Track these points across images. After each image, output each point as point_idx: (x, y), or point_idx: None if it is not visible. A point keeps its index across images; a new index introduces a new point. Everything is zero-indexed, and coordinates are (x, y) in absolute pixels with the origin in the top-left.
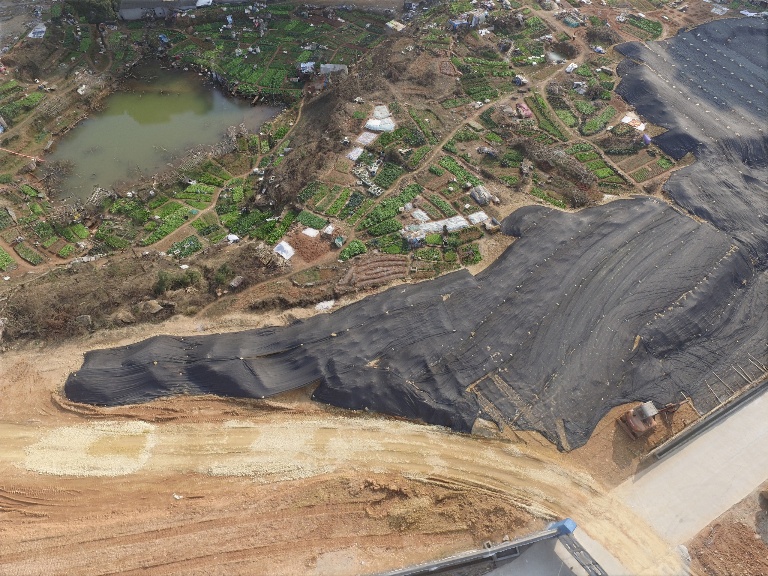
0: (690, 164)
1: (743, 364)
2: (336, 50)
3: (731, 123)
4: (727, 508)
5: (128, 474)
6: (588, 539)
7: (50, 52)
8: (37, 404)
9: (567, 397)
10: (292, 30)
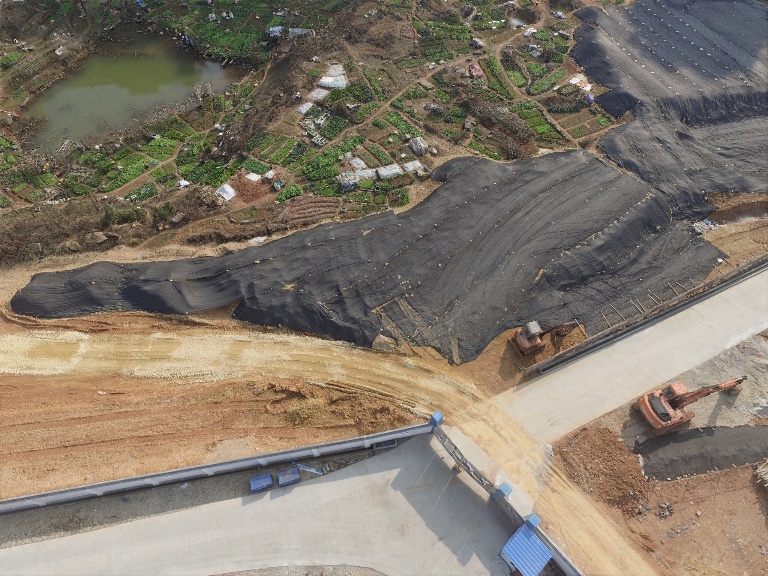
0: (628, 122)
1: (641, 298)
2: (307, 16)
3: (673, 83)
4: (597, 416)
5: (60, 374)
6: (462, 436)
7: (30, 14)
8: None
9: (465, 320)
10: None
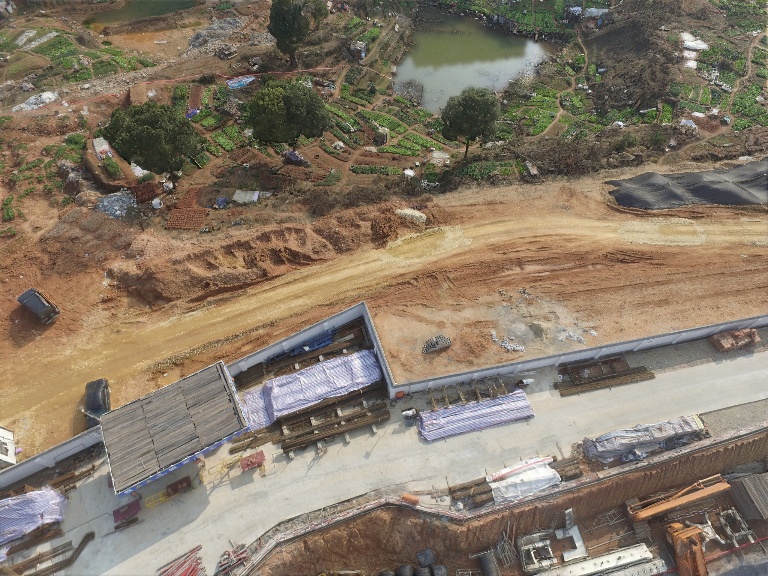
0: None
1: None
2: None
3: None
4: None
5: (700, 244)
6: None
7: None
8: (600, 209)
9: None
10: None
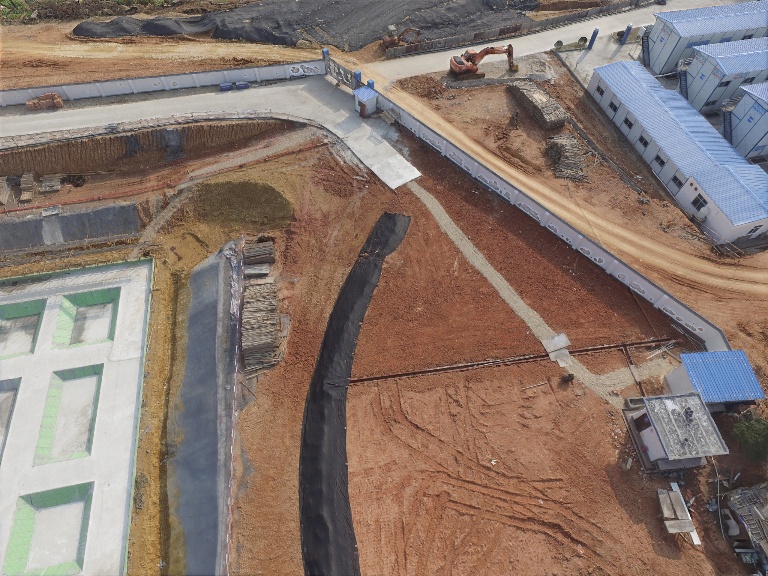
0: None
1: None
2: None
3: None
4: (427, 73)
5: (107, 57)
6: None
7: None
8: (58, 37)
9: (355, 36)
10: None
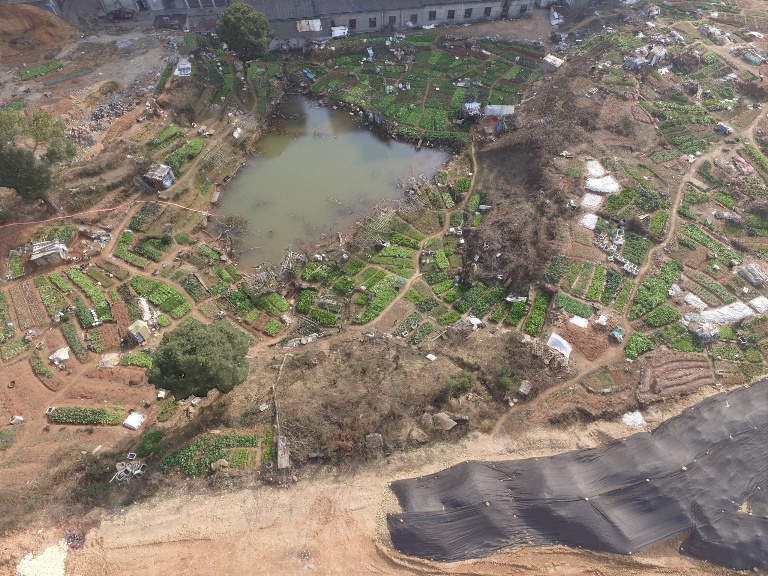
0: None
1: None
2: (491, 87)
3: None
4: None
5: None
6: None
7: (200, 91)
8: (363, 557)
9: None
10: (437, 63)
